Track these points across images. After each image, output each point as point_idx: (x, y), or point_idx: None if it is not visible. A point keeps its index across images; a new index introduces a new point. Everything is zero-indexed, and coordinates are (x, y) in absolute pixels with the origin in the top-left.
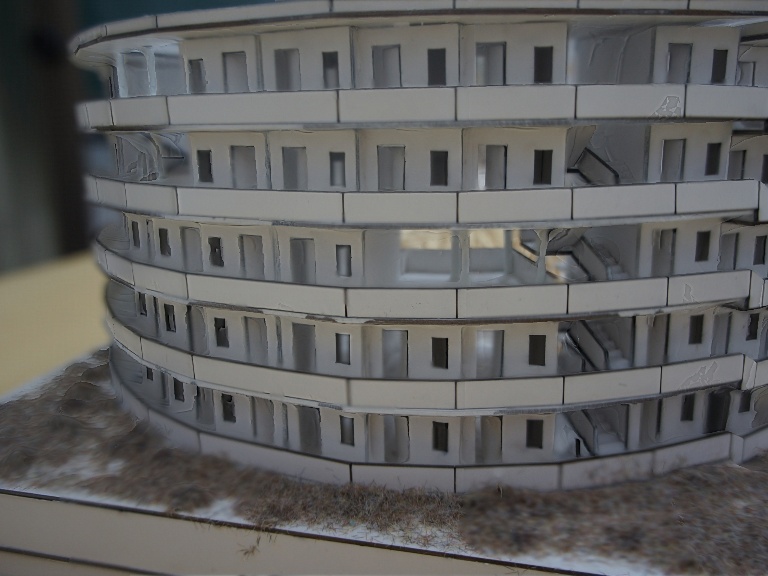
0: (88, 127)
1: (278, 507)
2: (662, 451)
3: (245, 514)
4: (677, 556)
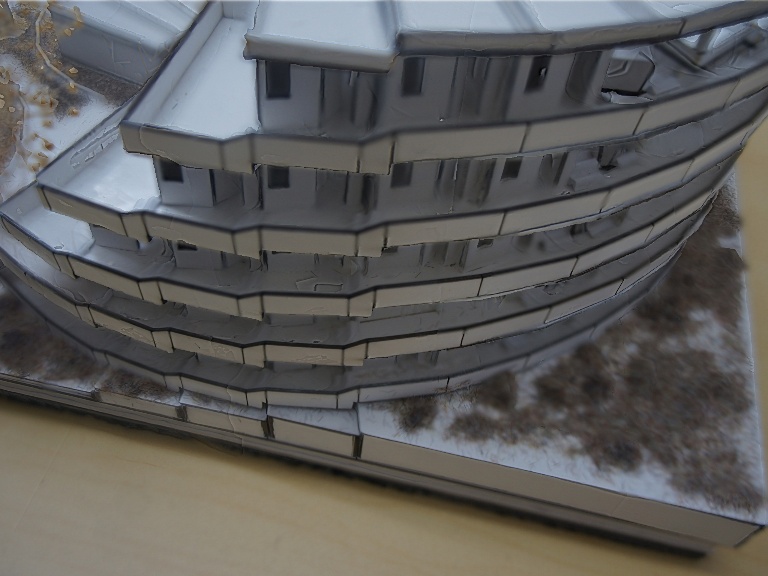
0: (721, 109)
1: (725, 216)
2: None
3: (736, 232)
4: None
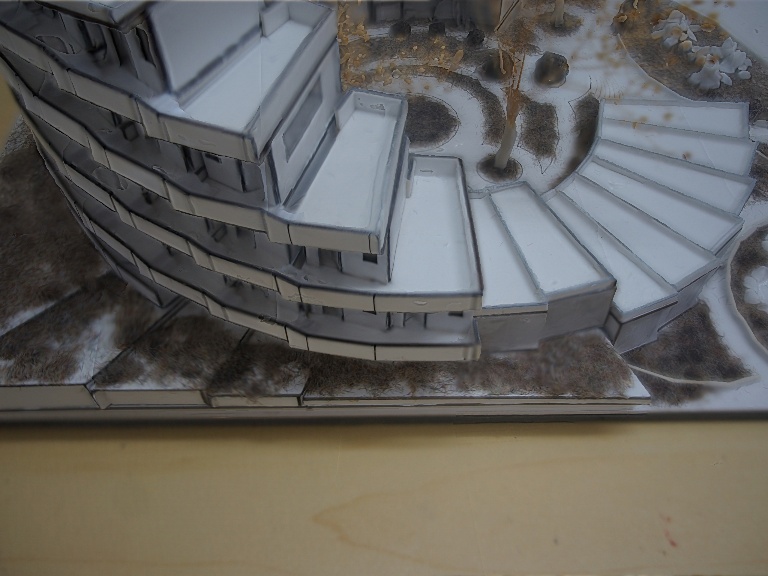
0: None
1: None
2: None
3: None
4: None
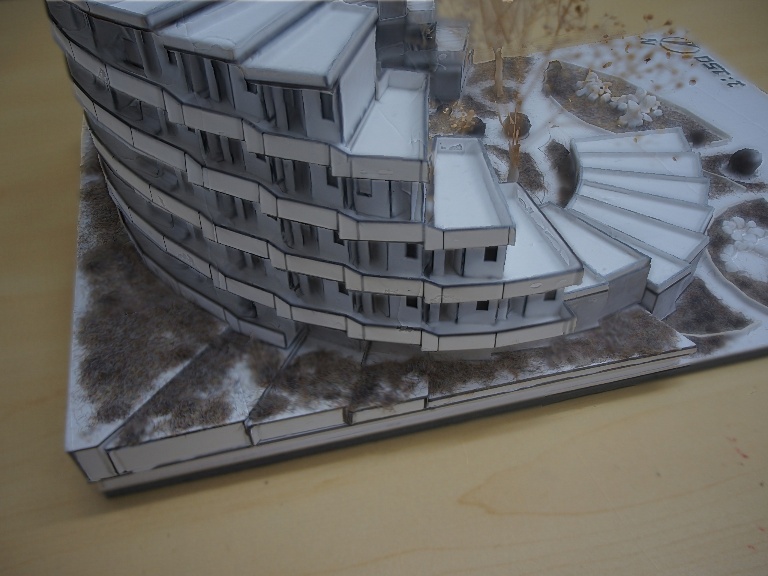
0: None
1: (92, 192)
2: (180, 285)
3: None
4: (90, 317)
